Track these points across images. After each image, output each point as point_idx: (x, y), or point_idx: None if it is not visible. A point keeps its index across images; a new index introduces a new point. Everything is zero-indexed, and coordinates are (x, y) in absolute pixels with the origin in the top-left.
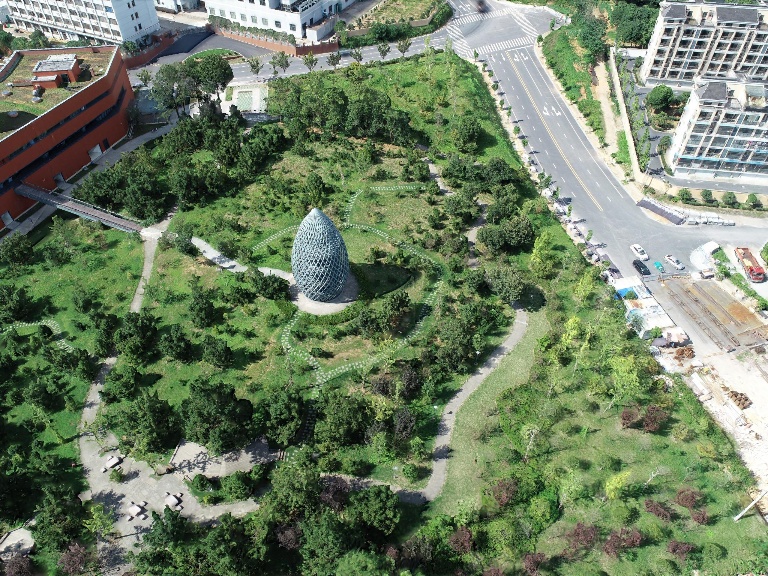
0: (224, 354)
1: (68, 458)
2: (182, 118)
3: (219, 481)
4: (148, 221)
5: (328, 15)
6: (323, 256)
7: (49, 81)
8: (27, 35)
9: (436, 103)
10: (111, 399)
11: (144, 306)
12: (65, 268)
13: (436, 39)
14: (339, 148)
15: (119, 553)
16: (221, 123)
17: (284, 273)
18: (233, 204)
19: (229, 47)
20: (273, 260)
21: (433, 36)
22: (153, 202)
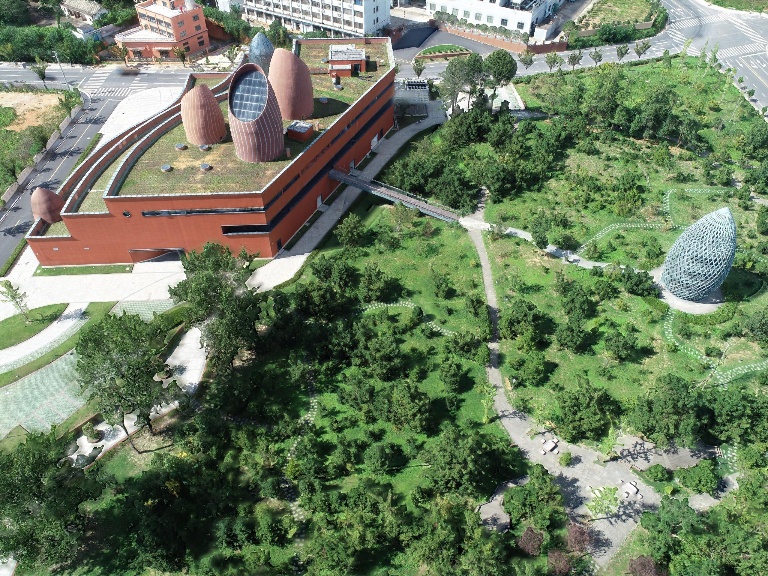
0: (630, 347)
1: (500, 438)
2: (457, 111)
3: (670, 473)
4: (465, 211)
5: (551, 15)
6: (724, 256)
7: (346, 70)
8: (258, 25)
9: (706, 107)
10: (518, 383)
11: (501, 294)
12: (398, 252)
13: (661, 42)
14: (624, 148)
15: (598, 535)
16: (500, 118)
17: (635, 270)
18: (545, 199)
19: (457, 43)
20: (617, 256)
21: (657, 39)
22: (470, 192)
